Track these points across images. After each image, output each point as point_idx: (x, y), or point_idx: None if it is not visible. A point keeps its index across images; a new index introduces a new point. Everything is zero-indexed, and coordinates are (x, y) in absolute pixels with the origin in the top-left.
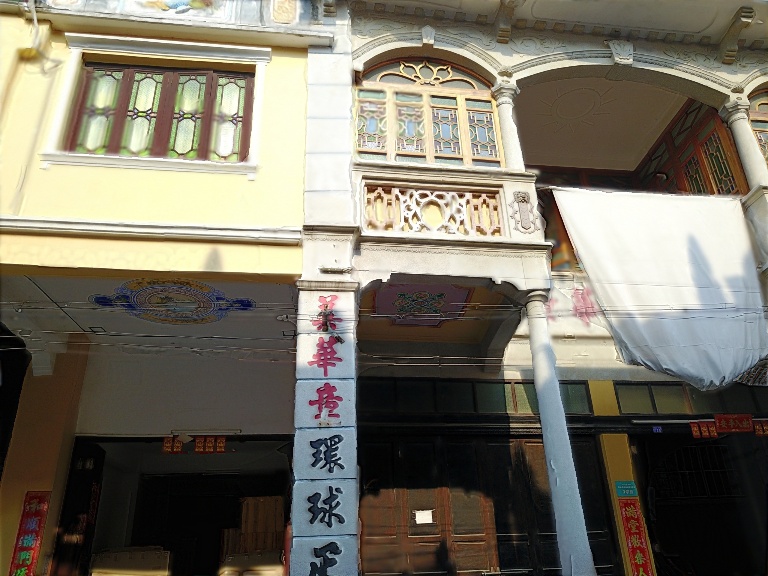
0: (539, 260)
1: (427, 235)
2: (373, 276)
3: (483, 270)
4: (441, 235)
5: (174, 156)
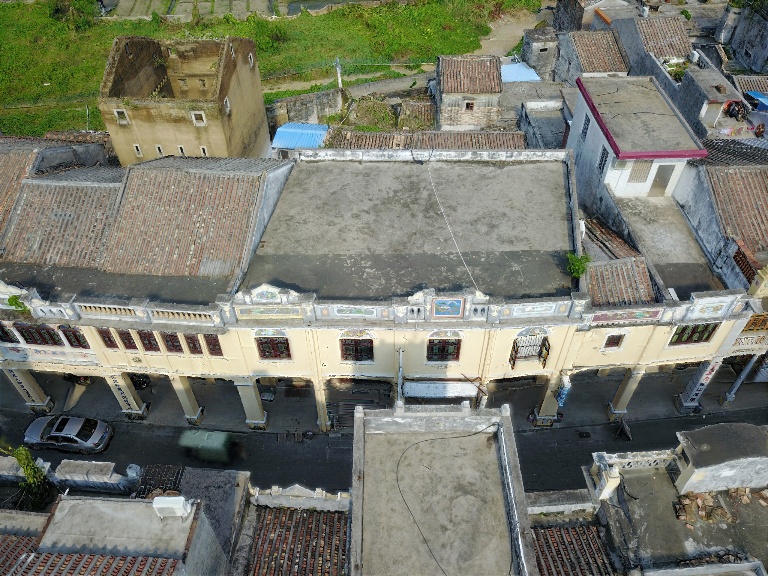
0: (765, 350)
1: (742, 347)
2: (725, 357)
3: (751, 353)
4: (746, 346)
5: (692, 341)
